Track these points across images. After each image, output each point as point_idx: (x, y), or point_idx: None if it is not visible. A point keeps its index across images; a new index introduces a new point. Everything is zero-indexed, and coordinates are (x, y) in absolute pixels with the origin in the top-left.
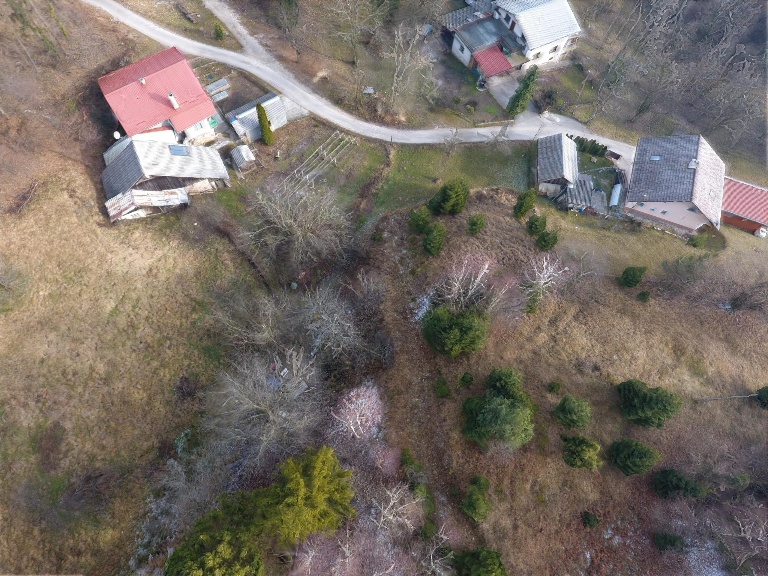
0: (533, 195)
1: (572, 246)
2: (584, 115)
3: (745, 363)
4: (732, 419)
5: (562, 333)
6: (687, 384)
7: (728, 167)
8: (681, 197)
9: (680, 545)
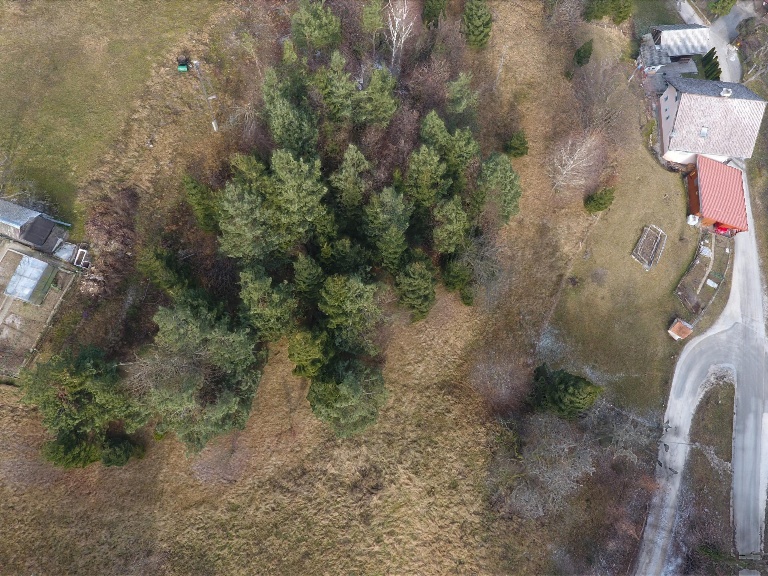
0: (629, 1)
1: (595, 38)
2: (754, 88)
3: (541, 146)
4: (488, 128)
5: (513, 7)
6: (504, 86)
7: (766, 221)
8: (683, 90)
9: (386, 31)
